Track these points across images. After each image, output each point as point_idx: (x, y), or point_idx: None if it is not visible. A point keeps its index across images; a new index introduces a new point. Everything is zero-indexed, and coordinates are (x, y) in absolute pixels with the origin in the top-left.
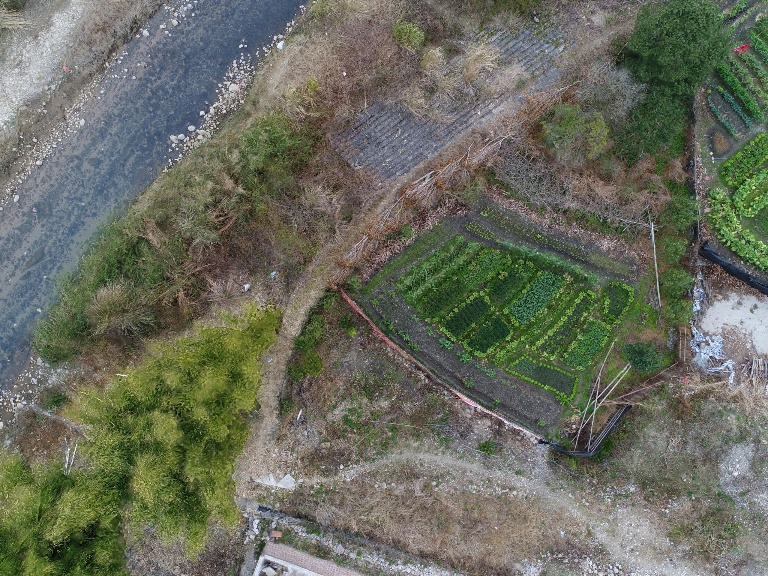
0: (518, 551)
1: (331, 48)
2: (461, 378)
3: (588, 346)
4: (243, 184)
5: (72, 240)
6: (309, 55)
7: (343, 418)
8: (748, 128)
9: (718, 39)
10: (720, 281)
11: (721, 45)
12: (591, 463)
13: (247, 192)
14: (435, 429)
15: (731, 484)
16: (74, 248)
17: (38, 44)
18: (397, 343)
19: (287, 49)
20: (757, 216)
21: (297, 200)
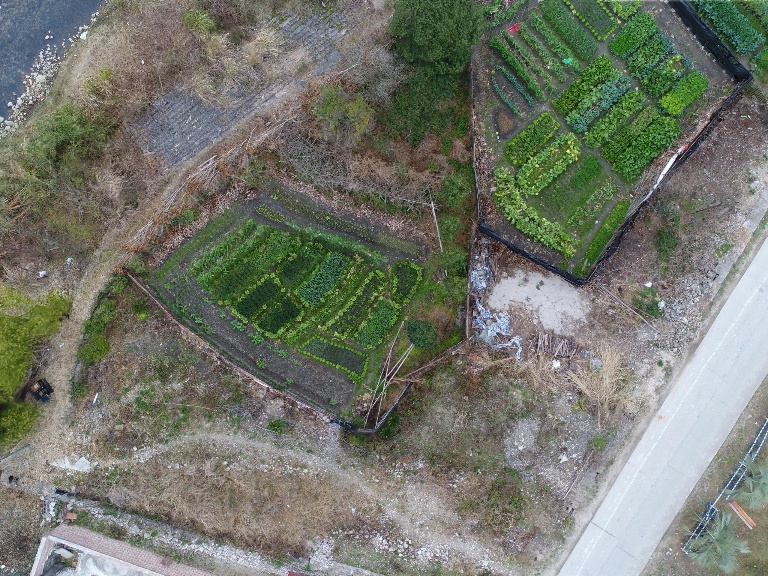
0: (310, 528)
1: (130, 37)
2: (254, 359)
3: (377, 325)
4: (37, 172)
5: None
6: (110, 45)
7: (136, 401)
8: (532, 107)
9: (468, 18)
10: (506, 258)
11: (472, 24)
12: (378, 440)
13: (43, 180)
14: (227, 410)
15: (517, 458)
16: None
17: None
18: (190, 326)
19: (90, 39)
20: (543, 194)
21: (84, 186)
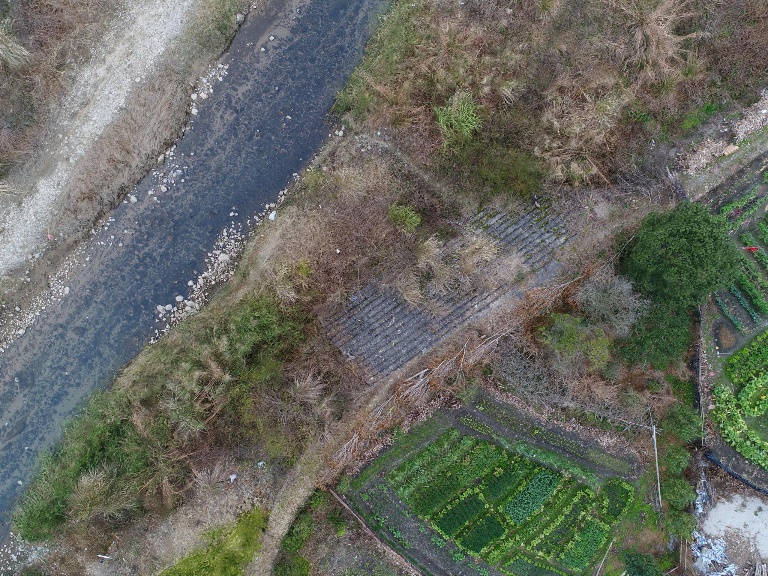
0: None
1: (324, 223)
2: None
3: (585, 548)
4: (231, 371)
5: (55, 410)
6: (302, 228)
7: None
8: (755, 323)
9: (726, 260)
10: (723, 482)
11: (729, 266)
12: None
13: (235, 377)
14: None
15: None
16: (57, 419)
17: (22, 211)
18: (387, 540)
19: (279, 220)
20: (763, 414)
21: (286, 395)
